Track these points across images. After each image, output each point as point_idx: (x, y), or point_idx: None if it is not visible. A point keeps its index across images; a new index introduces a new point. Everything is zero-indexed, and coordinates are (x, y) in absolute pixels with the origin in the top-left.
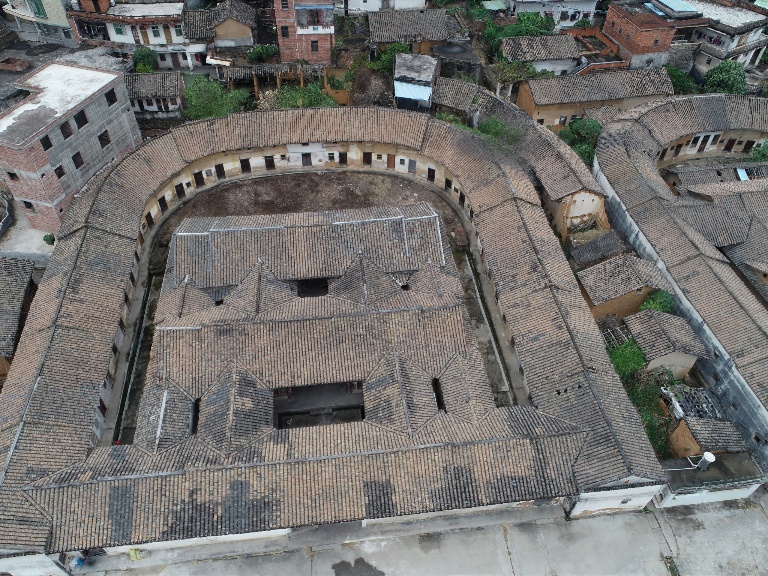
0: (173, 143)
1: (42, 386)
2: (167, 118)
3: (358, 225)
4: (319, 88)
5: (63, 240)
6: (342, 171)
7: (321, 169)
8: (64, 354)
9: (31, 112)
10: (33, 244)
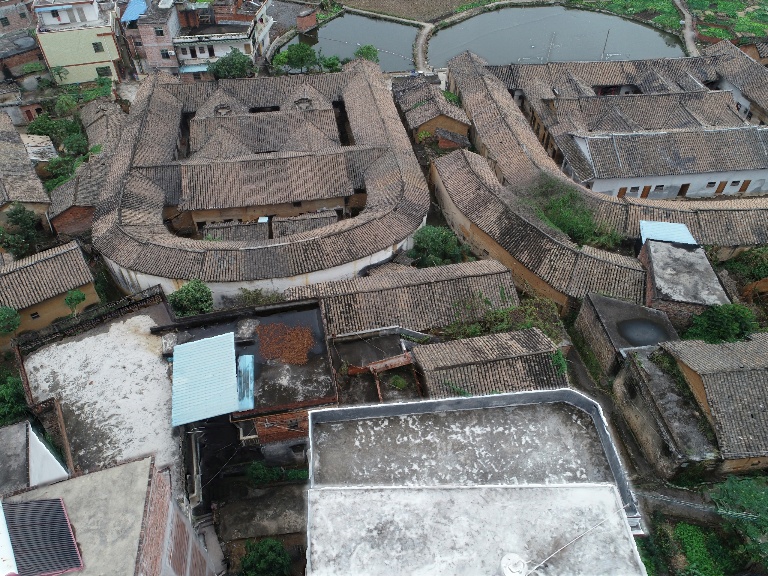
0: None
1: (764, 72)
2: None
3: None
4: None
5: None
6: None
7: None
8: None
9: None
10: None
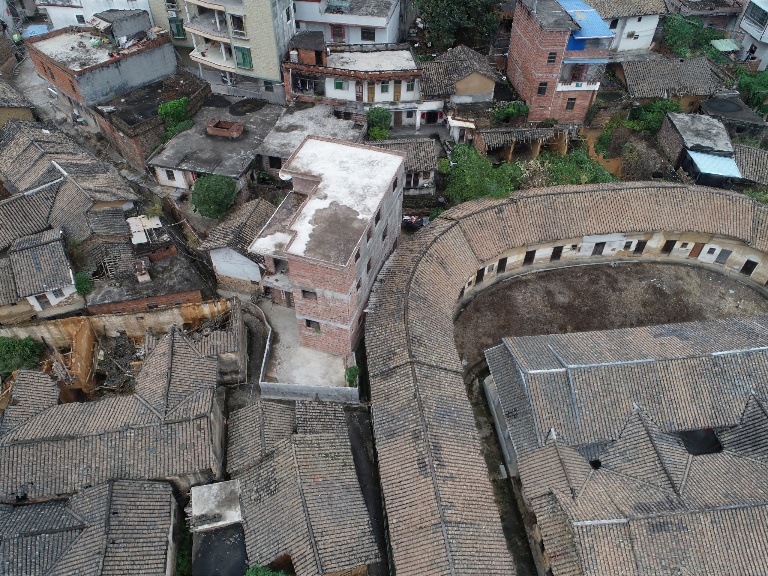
0: (462, 237)
1: None
2: (418, 195)
3: (742, 355)
4: (586, 156)
5: (379, 378)
6: (637, 261)
7: (612, 259)
8: (470, 567)
9: (326, 212)
10: (313, 370)
